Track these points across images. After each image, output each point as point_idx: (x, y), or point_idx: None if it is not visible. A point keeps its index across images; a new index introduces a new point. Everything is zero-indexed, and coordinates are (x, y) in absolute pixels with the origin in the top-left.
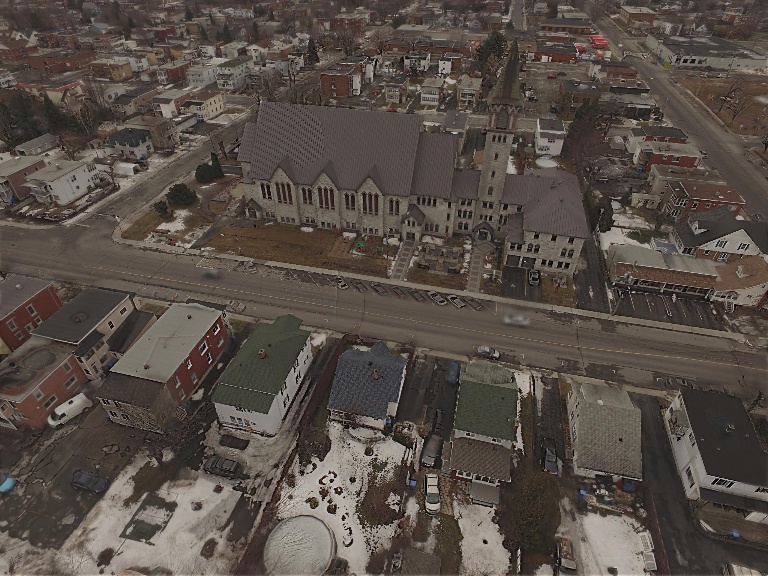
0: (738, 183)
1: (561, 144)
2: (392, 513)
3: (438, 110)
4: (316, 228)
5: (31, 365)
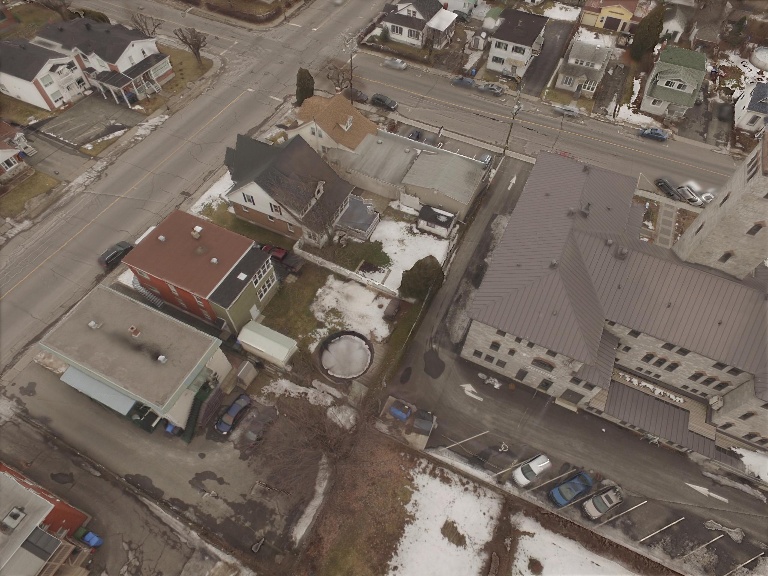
0: None
1: None
2: (721, 68)
3: None
4: None
5: None
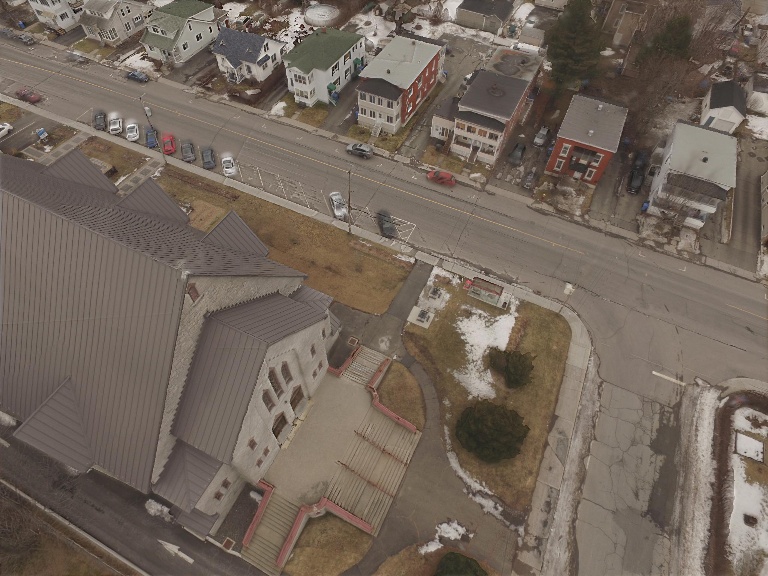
0: None
1: None
2: None
3: None
4: None
5: (510, 65)
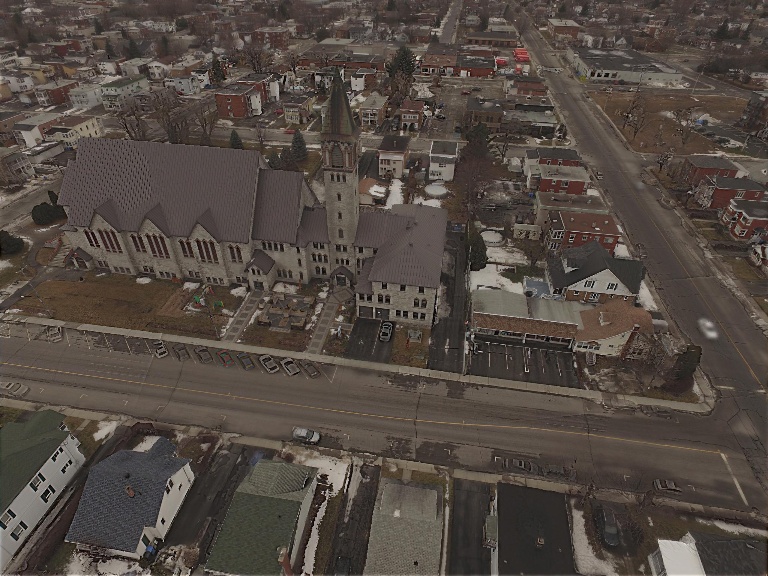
0: (628, 207)
1: (452, 169)
2: None
3: None
4: (155, 278)
5: None
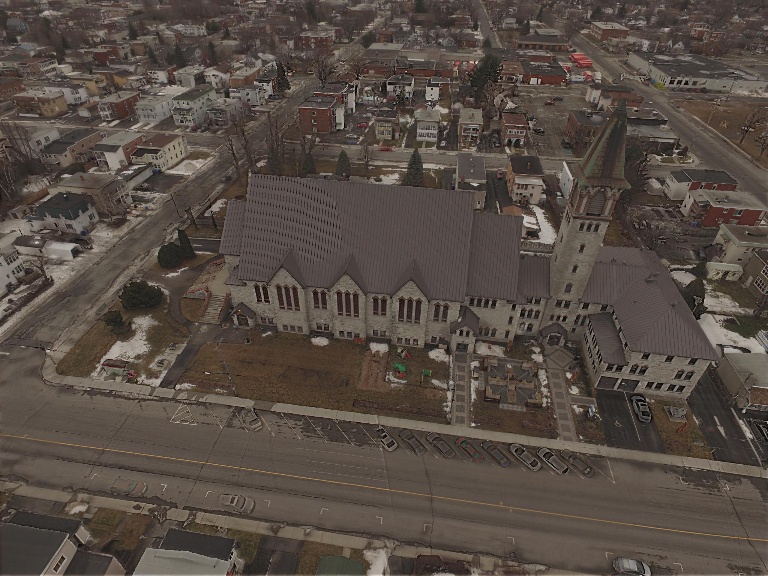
0: None
1: None
2: None
3: (438, 148)
4: (332, 338)
5: None
